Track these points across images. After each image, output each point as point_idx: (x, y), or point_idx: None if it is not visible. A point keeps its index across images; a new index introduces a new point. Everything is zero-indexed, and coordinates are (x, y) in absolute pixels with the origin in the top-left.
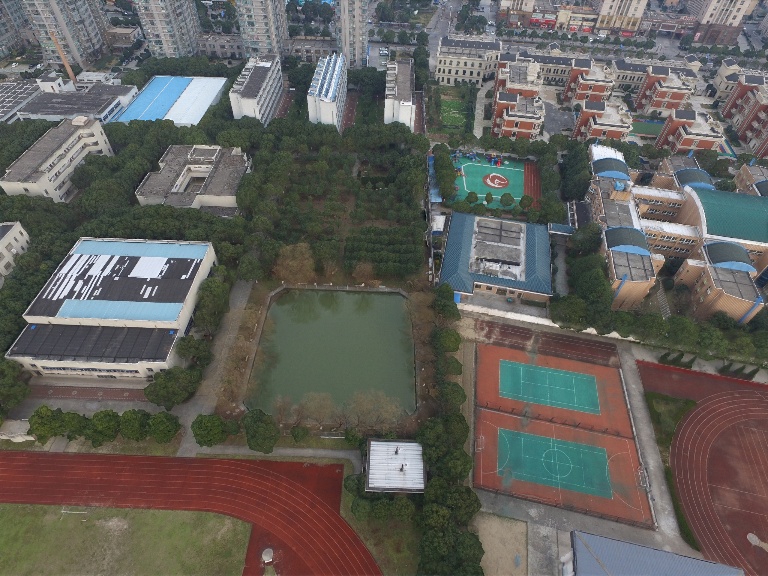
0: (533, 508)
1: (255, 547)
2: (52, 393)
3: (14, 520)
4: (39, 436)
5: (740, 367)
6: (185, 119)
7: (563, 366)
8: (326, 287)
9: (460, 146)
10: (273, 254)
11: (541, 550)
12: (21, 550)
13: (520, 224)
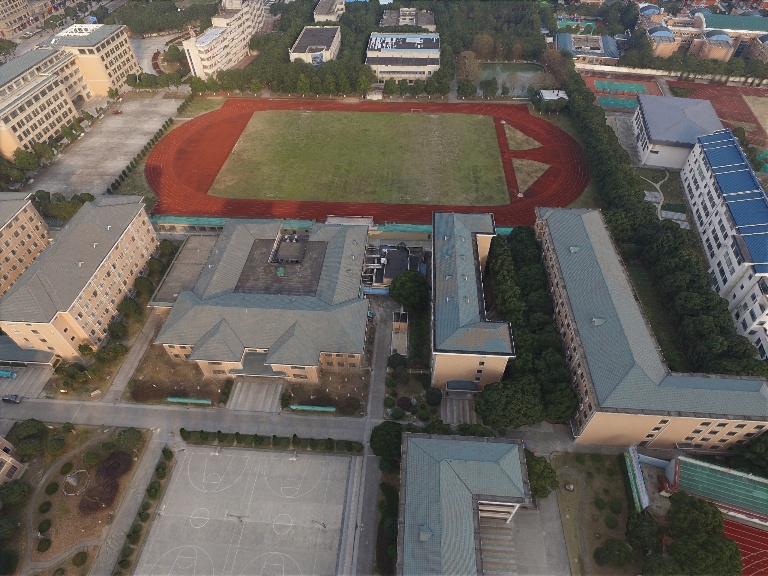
0: (617, 113)
1: (497, 120)
2: (379, 89)
3: (390, 115)
4: (389, 92)
5: (720, 77)
6: (383, 2)
7: (627, 82)
8: (495, 61)
9: (554, 13)
10: (470, 40)
11: (622, 121)
12: (399, 120)
13: (598, 37)
